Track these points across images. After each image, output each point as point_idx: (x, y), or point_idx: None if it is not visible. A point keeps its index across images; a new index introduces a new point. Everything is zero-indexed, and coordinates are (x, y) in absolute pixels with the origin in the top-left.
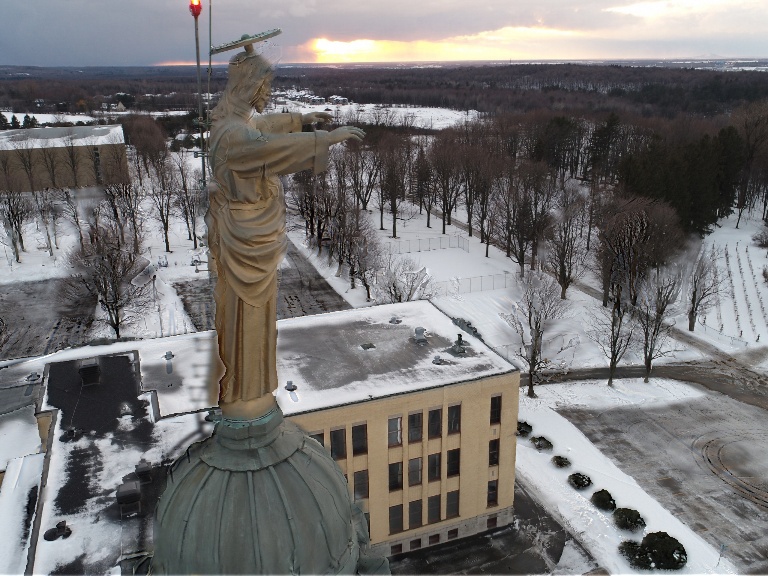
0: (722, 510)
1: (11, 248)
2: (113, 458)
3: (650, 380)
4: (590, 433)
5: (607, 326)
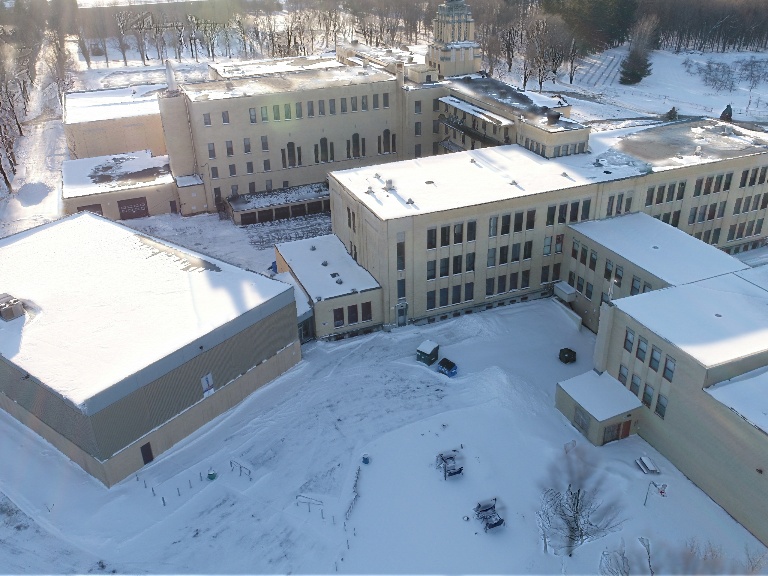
0: None
1: (205, 55)
2: None
3: (542, 93)
4: None
5: (523, 66)
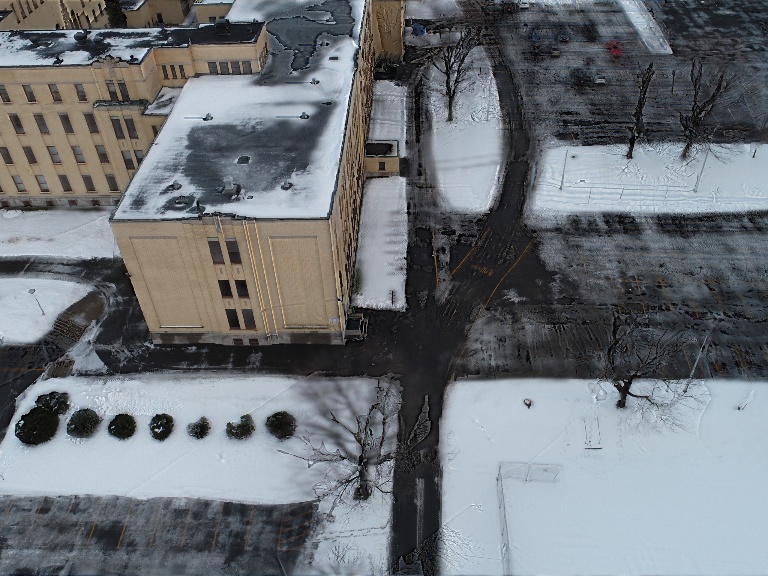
0: (42, 557)
1: None
2: (129, 40)
3: None
4: (245, 514)
5: None
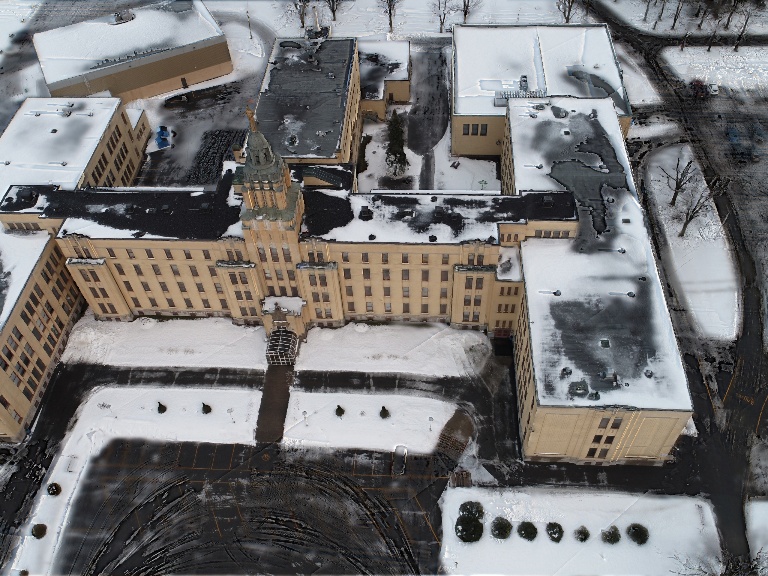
0: None
1: None
2: (474, 211)
3: None
4: None
5: None
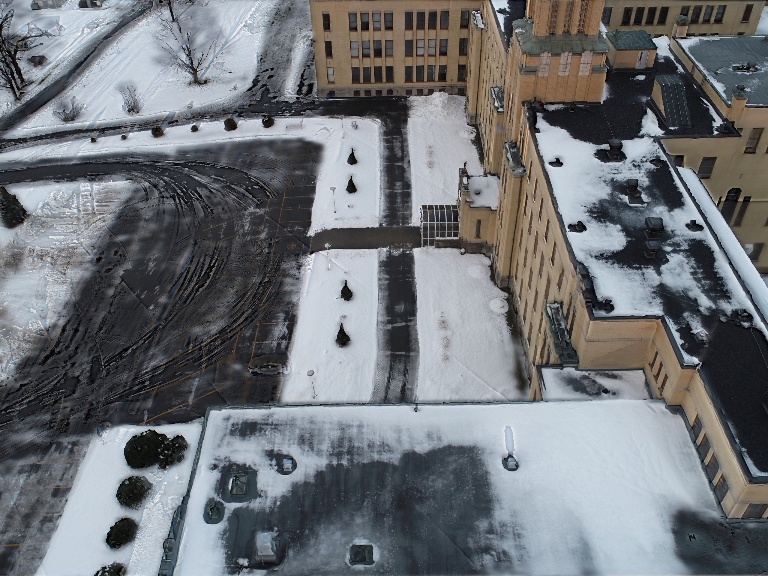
0: (5, 508)
1: None
2: (687, 281)
3: None
4: None
5: None
